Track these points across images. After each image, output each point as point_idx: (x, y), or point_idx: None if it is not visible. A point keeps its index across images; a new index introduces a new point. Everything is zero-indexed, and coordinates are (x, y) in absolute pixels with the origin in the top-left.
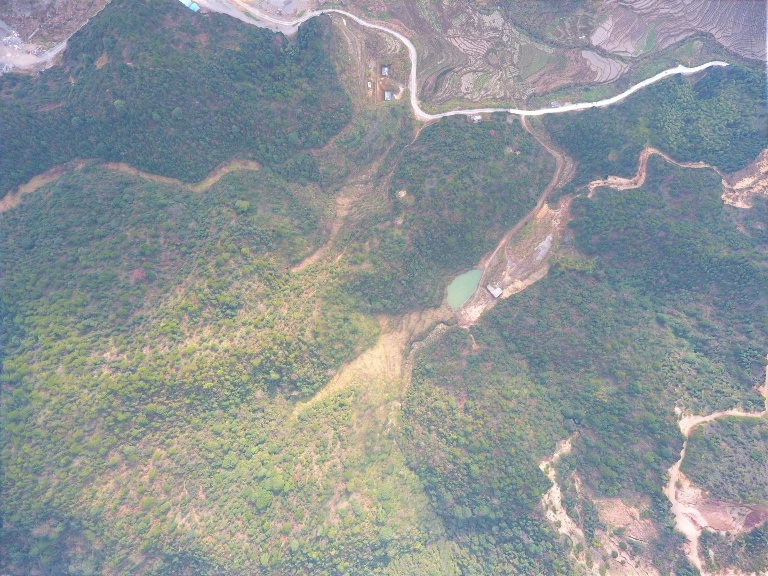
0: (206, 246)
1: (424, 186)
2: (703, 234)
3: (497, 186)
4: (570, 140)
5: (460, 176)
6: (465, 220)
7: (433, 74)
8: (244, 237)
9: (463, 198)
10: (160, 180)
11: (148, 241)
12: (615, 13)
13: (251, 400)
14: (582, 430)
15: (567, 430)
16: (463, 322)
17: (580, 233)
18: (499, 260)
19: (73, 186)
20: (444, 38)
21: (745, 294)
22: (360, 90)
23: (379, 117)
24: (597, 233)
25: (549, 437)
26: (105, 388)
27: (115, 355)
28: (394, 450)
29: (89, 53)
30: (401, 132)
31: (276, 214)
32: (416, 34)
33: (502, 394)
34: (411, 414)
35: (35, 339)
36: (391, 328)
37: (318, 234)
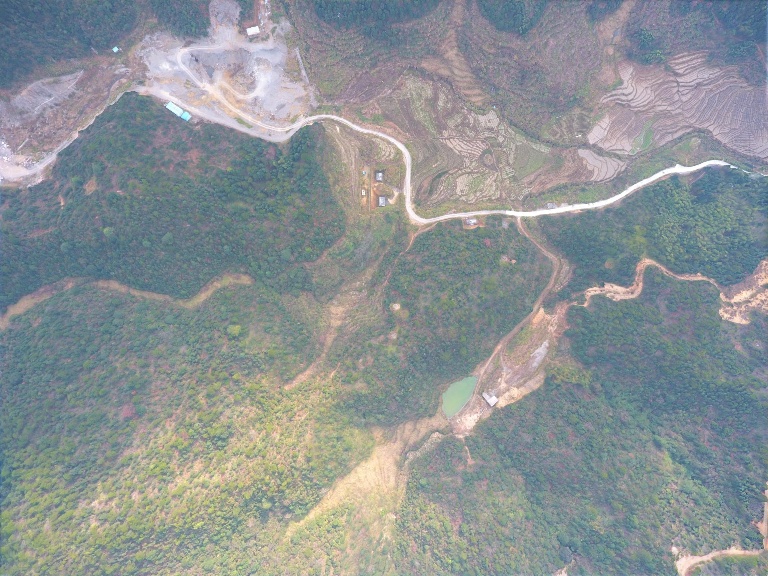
0: (197, 376)
1: (418, 303)
2: (700, 357)
3: (492, 301)
4: (566, 244)
5: (455, 294)
6: (460, 338)
7: (428, 177)
8: (236, 363)
9: (458, 316)
10: (151, 297)
11: (138, 372)
12: (612, 111)
13: (243, 529)
14: (578, 558)
15: (563, 561)
16: (458, 431)
17: (576, 344)
18: (495, 367)
19: (62, 313)
20: (439, 140)
21: (743, 422)
22: (354, 199)
23: (373, 225)
24: (594, 345)
25: (545, 569)
26: (93, 544)
27: (103, 503)
28: (388, 567)
29: (79, 173)
30: (395, 238)
31: (268, 334)
32: (411, 137)
33: (497, 519)
34: (406, 529)
35: (21, 494)
36: (385, 439)
37: (311, 349)
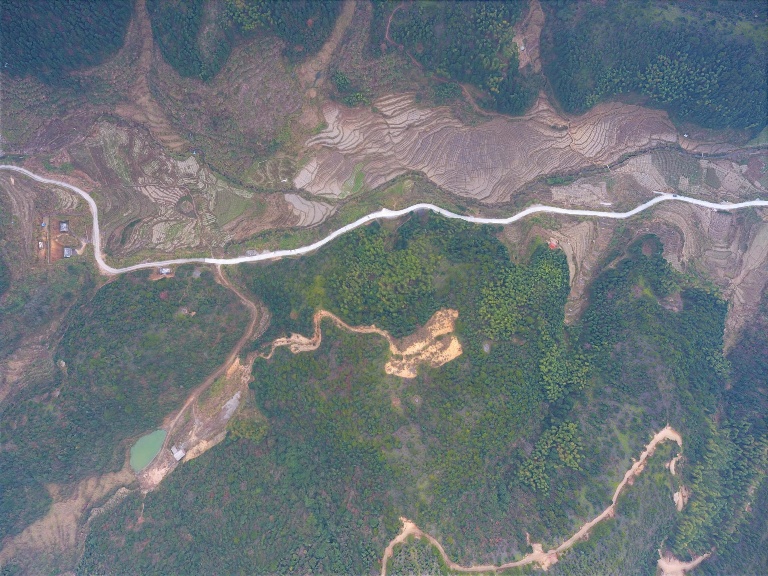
0: None
1: (75, 360)
2: (345, 416)
3: (155, 357)
4: (260, 293)
5: (107, 352)
6: (116, 396)
7: (120, 226)
8: None
9: (110, 375)
10: None
11: None
12: (319, 154)
13: None
14: None
15: None
16: (145, 486)
17: (255, 397)
18: (185, 420)
19: None
20: (133, 188)
21: (378, 483)
22: (26, 253)
23: (50, 278)
24: (268, 399)
25: None
26: None
27: None
28: None
29: None
30: (82, 289)
31: None
32: (100, 186)
33: None
34: None
35: None
36: (63, 497)
37: None
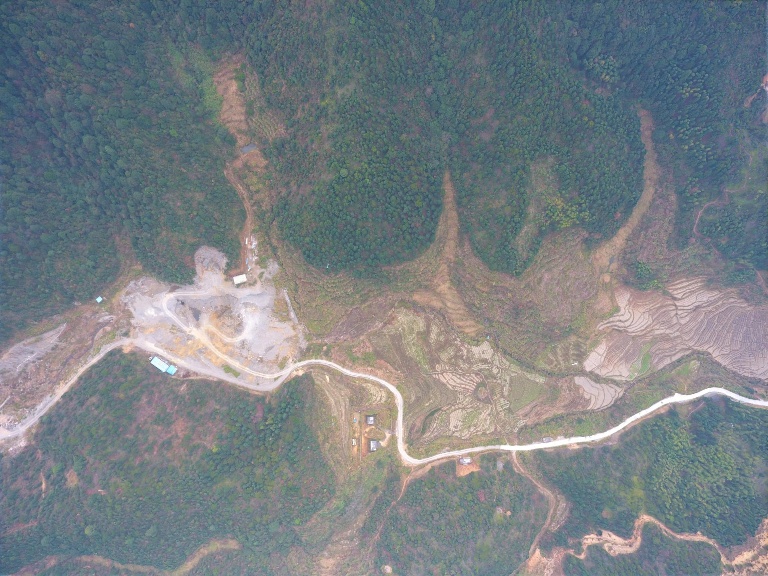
0: None
1: (410, 573)
2: None
3: None
4: (563, 485)
5: (448, 568)
6: None
7: (420, 416)
8: None
9: None
10: (136, 568)
11: None
12: (609, 337)
13: None
14: None
15: None
16: None
17: None
18: None
19: None
20: (432, 376)
21: None
22: (344, 453)
23: (364, 477)
24: None
25: None
26: None
27: None
28: None
29: (60, 455)
30: (387, 482)
31: None
32: (402, 376)
33: None
34: None
35: None
36: None
37: None
